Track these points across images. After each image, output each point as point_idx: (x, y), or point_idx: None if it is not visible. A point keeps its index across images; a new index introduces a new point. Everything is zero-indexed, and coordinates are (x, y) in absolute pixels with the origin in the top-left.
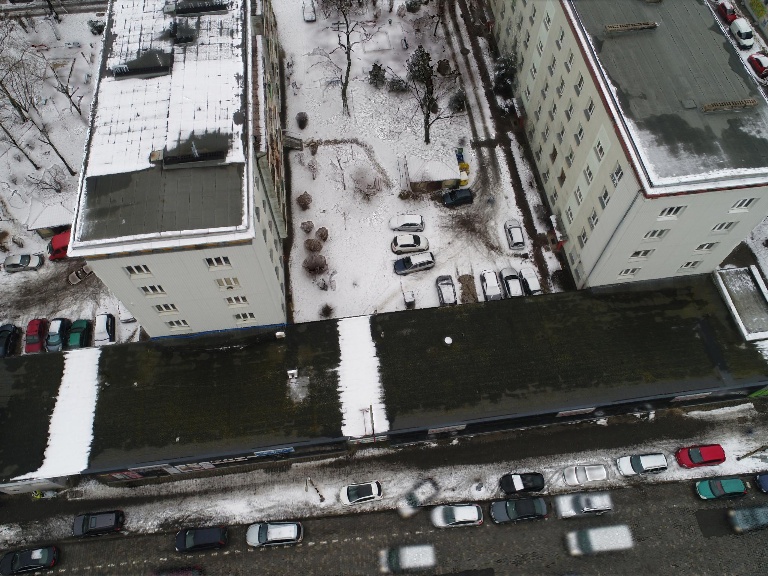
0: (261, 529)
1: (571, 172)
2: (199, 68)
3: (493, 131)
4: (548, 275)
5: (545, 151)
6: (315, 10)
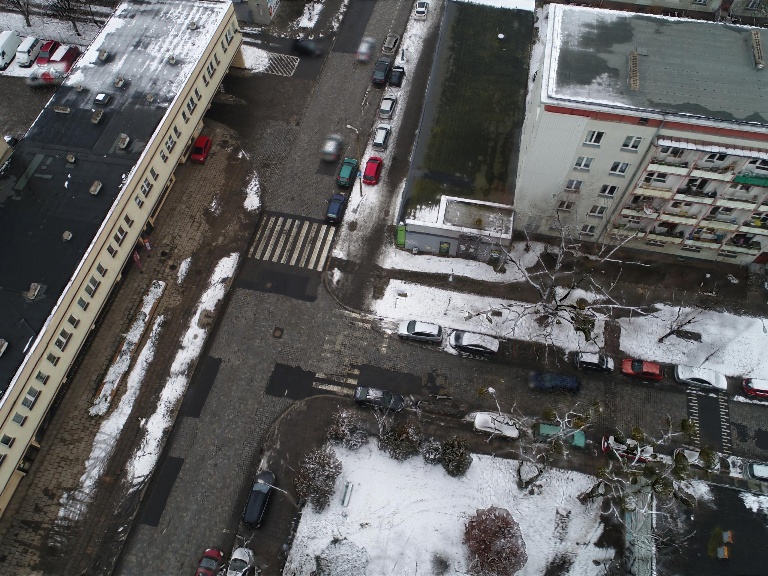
0: None
1: None
2: None
3: None
4: None
5: None
6: None
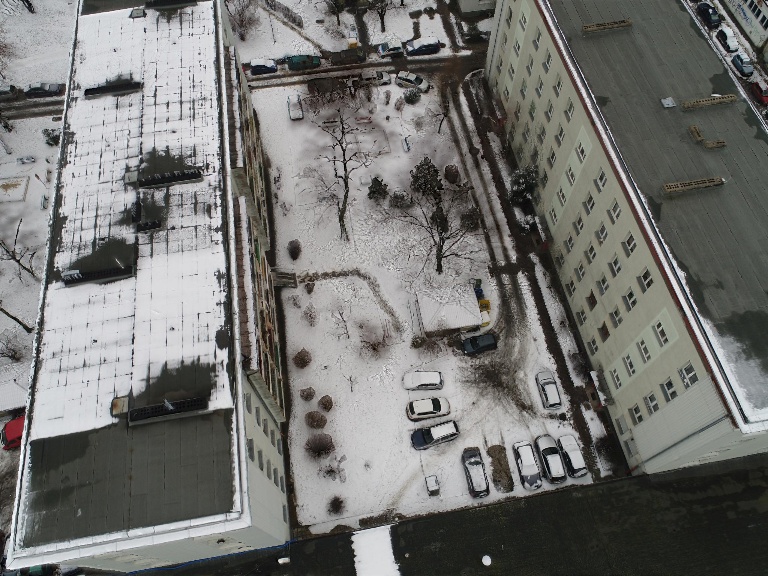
0: None
1: (618, 334)
2: (170, 265)
3: (513, 253)
4: (591, 442)
5: (579, 291)
6: (302, 105)
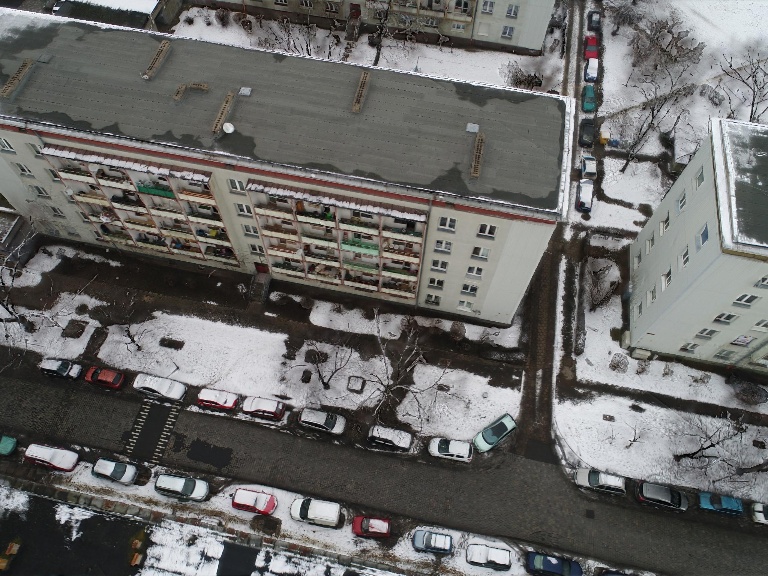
0: None
1: None
2: None
3: None
4: None
5: None
6: None
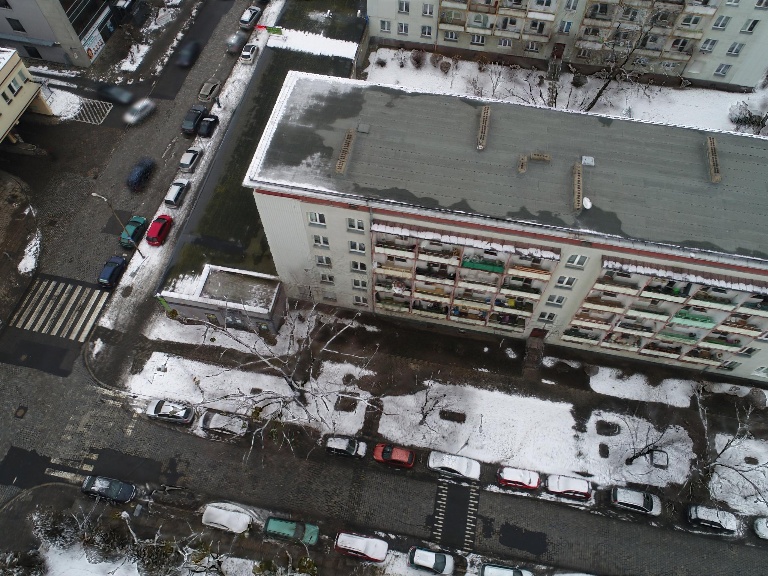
0: (255, 10)
1: None
2: None
3: None
4: None
5: None
6: None
